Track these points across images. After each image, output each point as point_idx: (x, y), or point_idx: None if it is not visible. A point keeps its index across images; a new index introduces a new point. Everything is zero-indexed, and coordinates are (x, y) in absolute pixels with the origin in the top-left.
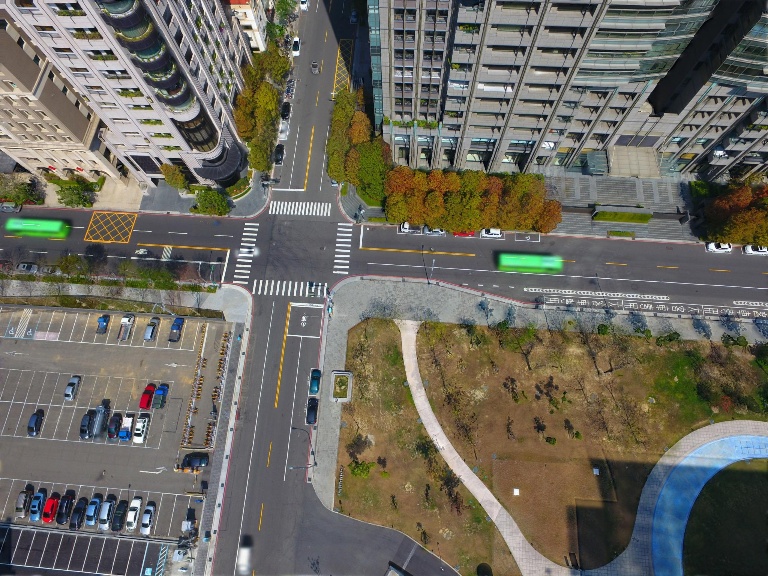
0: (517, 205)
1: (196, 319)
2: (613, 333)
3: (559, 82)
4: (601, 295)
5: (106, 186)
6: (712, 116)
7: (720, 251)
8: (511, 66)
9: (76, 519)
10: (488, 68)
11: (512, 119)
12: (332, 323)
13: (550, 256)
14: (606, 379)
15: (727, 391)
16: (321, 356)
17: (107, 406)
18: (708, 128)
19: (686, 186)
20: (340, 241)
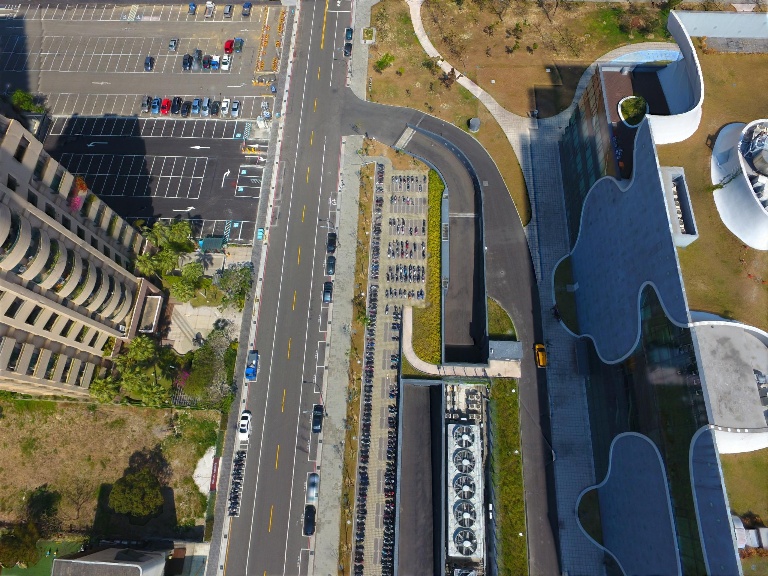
0: None
1: (260, 5)
2: (561, 0)
3: None
4: None
5: None
6: None
7: None
8: None
9: (185, 108)
10: None
11: None
12: (359, 3)
13: None
14: (556, 24)
15: (640, 27)
16: (352, 21)
17: (200, 53)
18: None
19: None
20: None
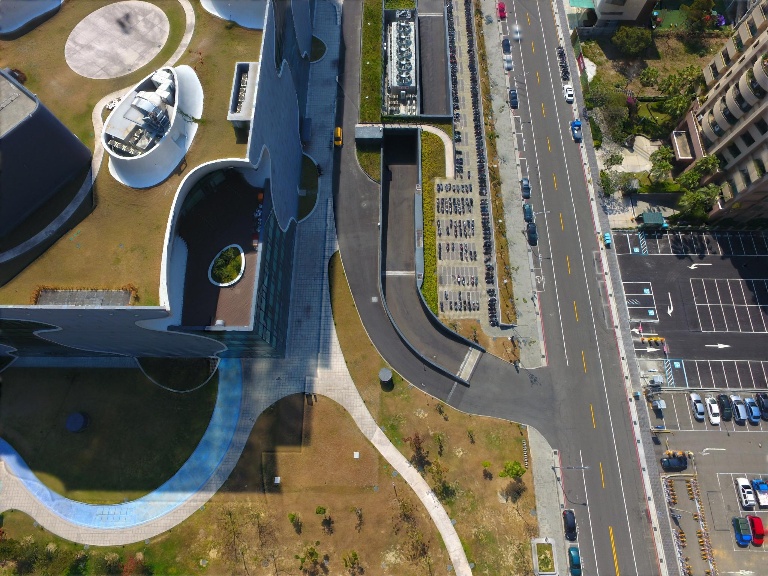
0: None
1: None
2: None
3: None
4: None
5: None
6: None
7: None
8: None
9: (765, 403)
10: None
11: None
12: None
13: None
14: None
15: None
16: None
17: None
18: None
19: None
20: None
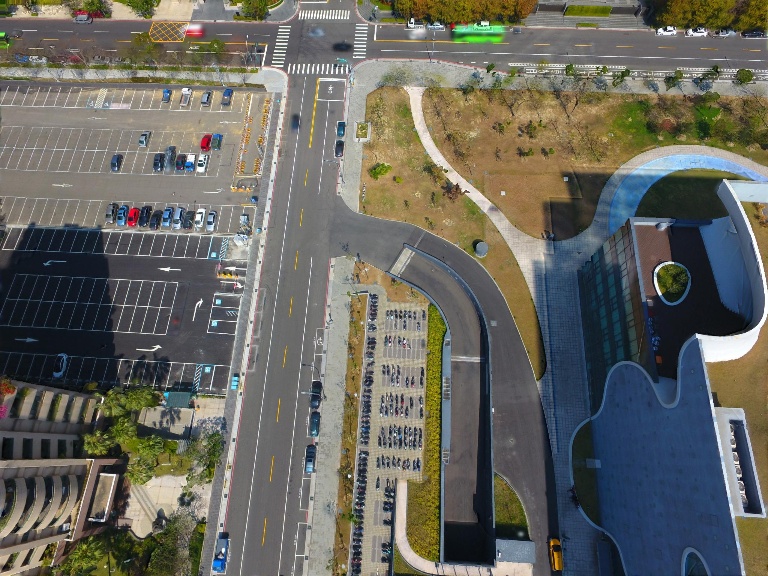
0: None
1: (242, 91)
2: None
3: None
4: None
5: (162, 4)
6: None
7: (667, 34)
8: None
9: (155, 220)
10: None
11: None
12: (353, 91)
13: (530, 42)
14: (574, 121)
15: None
16: (345, 113)
17: (173, 150)
18: None
19: None
20: (358, 36)
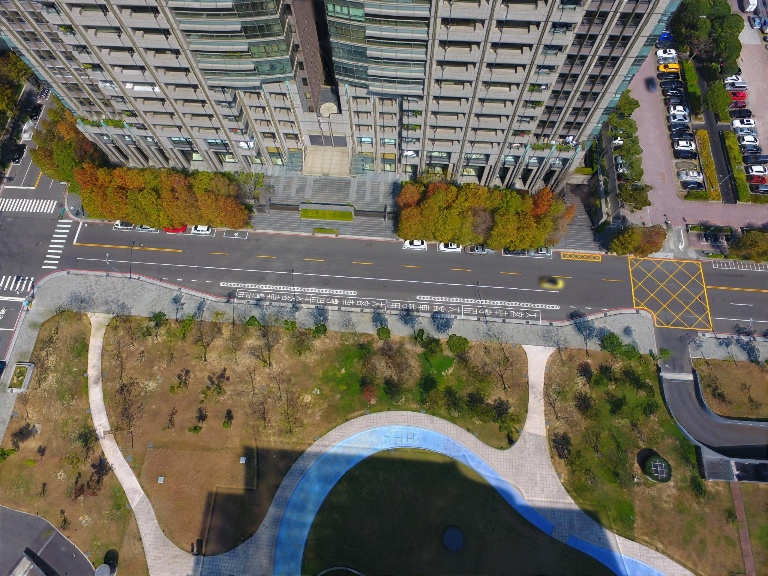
0: (190, 201)
1: None
2: None
3: (193, 82)
4: (292, 290)
5: None
6: (373, 116)
7: (415, 248)
8: (136, 66)
9: None
10: (123, 68)
11: (185, 118)
12: (28, 316)
13: (253, 252)
14: (276, 371)
15: (389, 383)
16: (10, 348)
17: None
18: (382, 128)
19: (398, 185)
20: (56, 237)
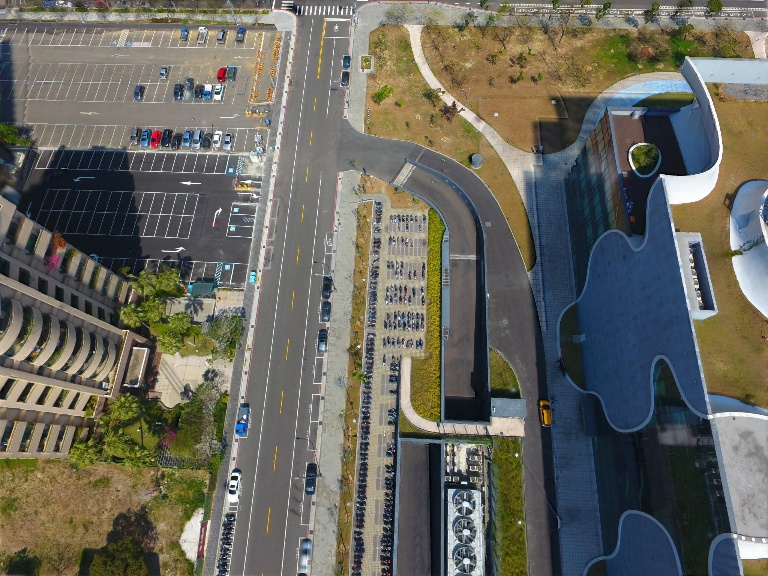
0: None
1: (255, 30)
2: (566, 26)
3: None
4: None
5: None
6: None
7: None
8: None
9: (176, 140)
10: None
11: None
12: (357, 29)
13: None
14: (561, 53)
15: (649, 56)
16: (350, 48)
17: (192, 82)
18: None
19: None
20: None
